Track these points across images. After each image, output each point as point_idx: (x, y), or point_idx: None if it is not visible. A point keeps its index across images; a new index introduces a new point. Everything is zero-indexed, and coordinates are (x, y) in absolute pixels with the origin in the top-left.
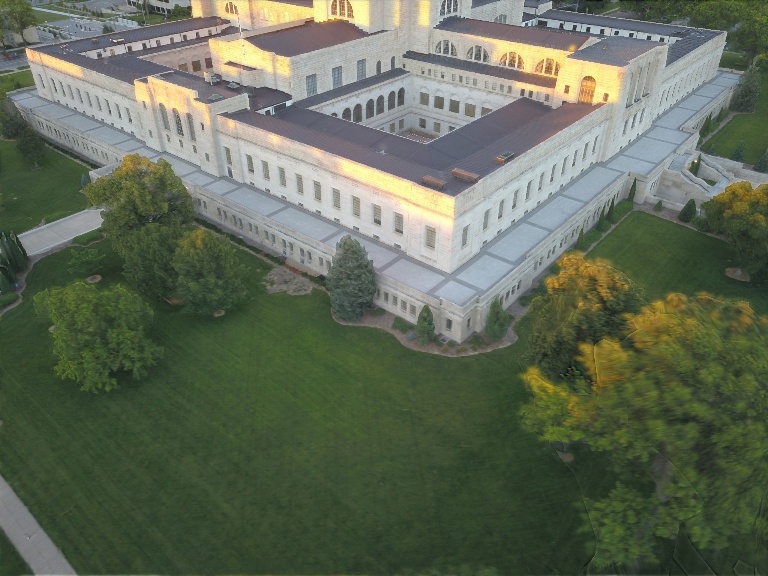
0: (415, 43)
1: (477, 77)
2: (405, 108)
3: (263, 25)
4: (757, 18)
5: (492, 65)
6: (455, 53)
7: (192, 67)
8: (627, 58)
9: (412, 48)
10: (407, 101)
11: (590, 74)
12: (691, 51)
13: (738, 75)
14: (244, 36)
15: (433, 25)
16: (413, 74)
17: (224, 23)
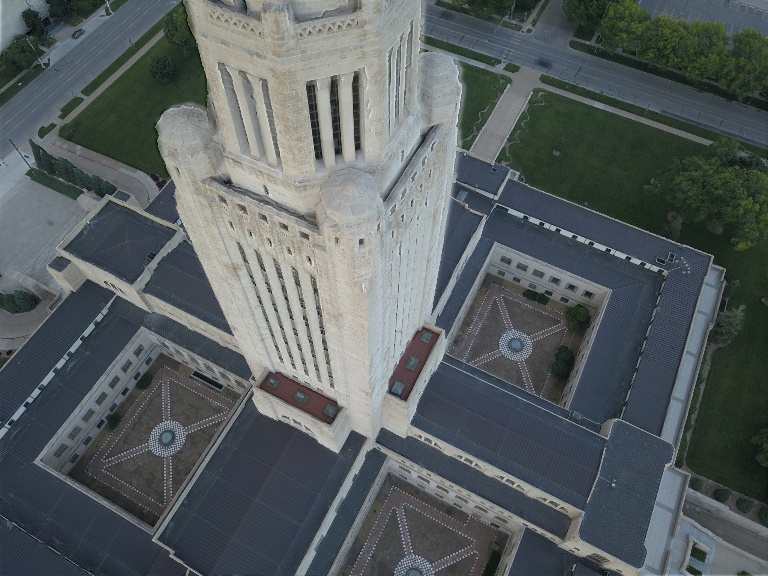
0: (389, 428)
1: (472, 496)
2: (383, 474)
3: (167, 314)
4: (742, 203)
5: (486, 475)
6: (439, 446)
7: (97, 405)
8: (641, 527)
9: (385, 427)
10: (385, 470)
11: (605, 557)
12: (684, 352)
13: (715, 273)
14: (187, 492)
15: (410, 421)
16: (391, 459)
17: (108, 300)
